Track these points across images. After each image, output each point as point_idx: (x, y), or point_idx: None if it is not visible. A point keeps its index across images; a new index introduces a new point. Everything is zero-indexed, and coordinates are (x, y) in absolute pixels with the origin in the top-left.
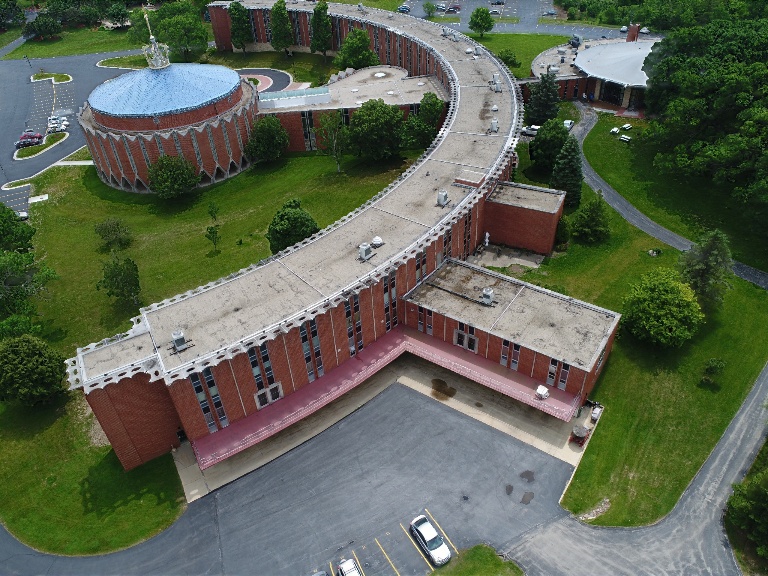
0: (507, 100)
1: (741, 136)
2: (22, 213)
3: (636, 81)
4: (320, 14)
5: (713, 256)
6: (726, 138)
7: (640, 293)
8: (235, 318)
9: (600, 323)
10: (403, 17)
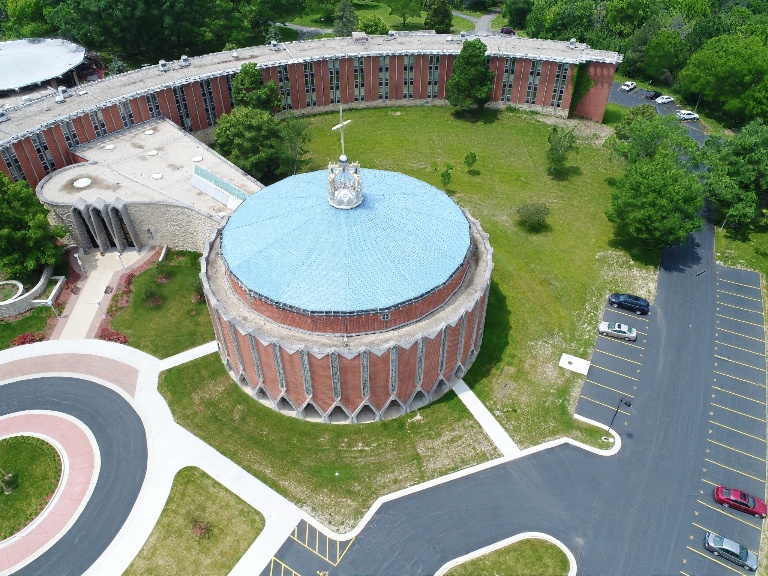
0: (209, 58)
1: None
2: (605, 327)
3: (62, 64)
4: None
5: (351, 7)
6: None
7: (382, 23)
8: (542, 46)
9: None
10: None
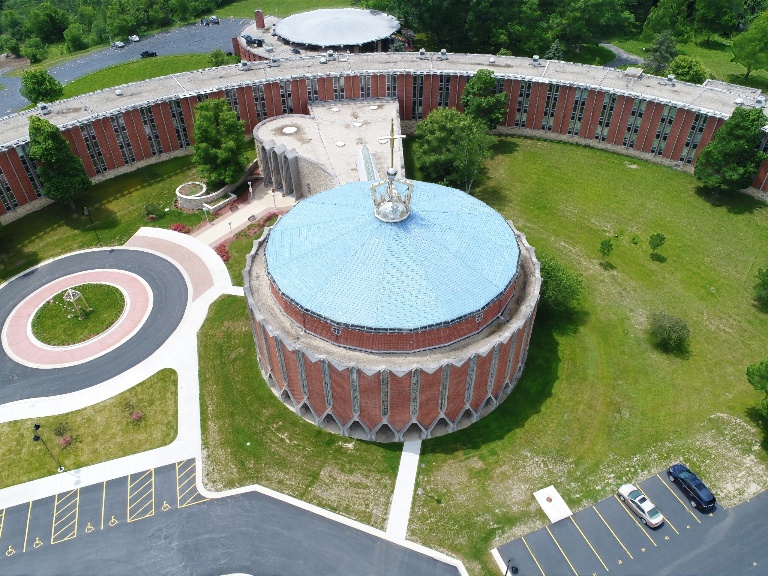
0: (469, 57)
1: (575, 3)
2: (627, 491)
3: (374, 35)
4: (59, 135)
5: None
6: (574, 7)
7: (698, 67)
8: None
9: (716, 85)
10: (133, 87)
